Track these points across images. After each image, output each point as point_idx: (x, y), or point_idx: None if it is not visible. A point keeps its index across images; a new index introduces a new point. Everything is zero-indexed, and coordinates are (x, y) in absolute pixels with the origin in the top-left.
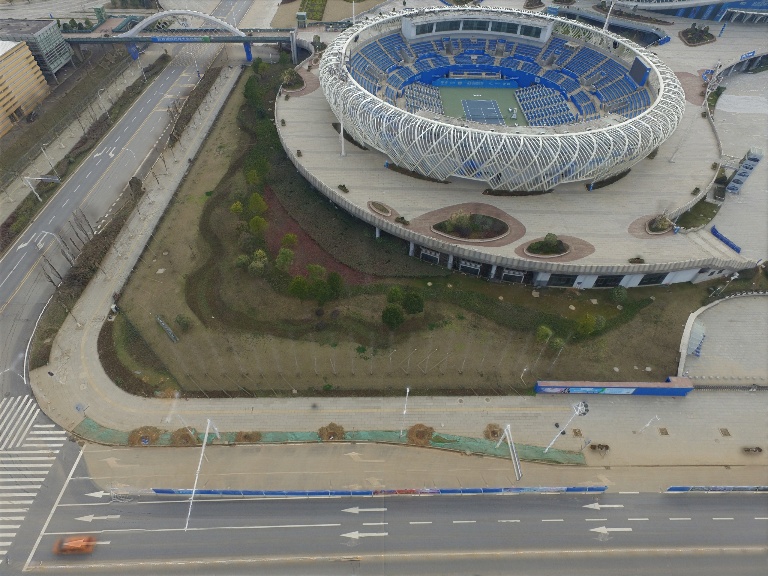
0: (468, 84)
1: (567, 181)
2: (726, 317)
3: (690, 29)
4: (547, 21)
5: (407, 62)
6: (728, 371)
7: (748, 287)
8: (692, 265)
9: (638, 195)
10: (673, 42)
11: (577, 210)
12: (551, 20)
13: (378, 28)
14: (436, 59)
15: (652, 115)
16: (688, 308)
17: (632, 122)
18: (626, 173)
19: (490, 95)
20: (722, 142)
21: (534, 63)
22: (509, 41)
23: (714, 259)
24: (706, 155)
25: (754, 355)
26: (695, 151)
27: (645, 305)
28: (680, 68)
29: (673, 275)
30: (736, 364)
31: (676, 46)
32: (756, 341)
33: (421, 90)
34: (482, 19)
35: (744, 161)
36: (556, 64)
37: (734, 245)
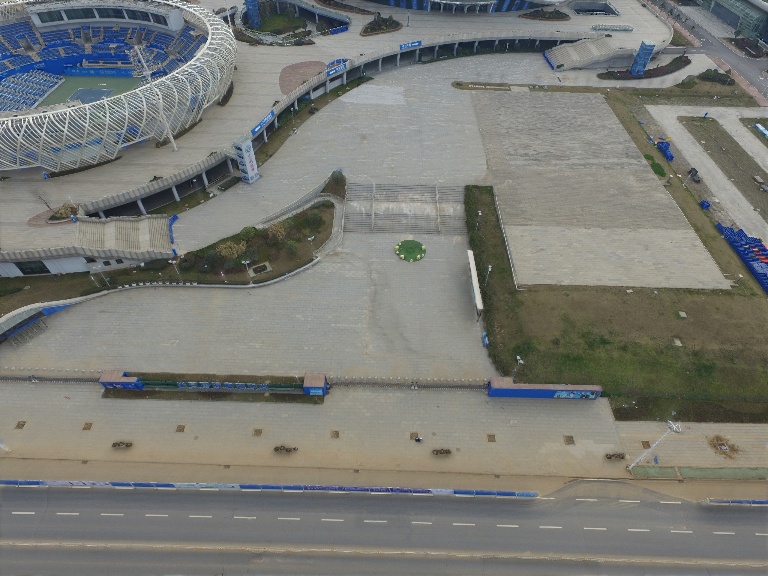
0: (101, 73)
1: (4, 169)
2: (100, 308)
3: (377, 18)
4: (172, 9)
5: (34, 50)
6: (34, 362)
7: (156, 278)
8: (51, 254)
9: (91, 184)
10: (350, 32)
11: (5, 198)
12: (177, 8)
13: (11, 16)
14: (69, 47)
15: (111, 102)
16: (48, 298)
17: (77, 109)
18: (109, 162)
19: (116, 84)
20: (300, 132)
21: (164, 52)
22: (150, 29)
23: (76, 248)
24: (221, 144)
25: (82, 346)
26: (215, 140)
27: (2, 294)
28: (320, 57)
29: (53, 264)
30: (51, 355)
31: (347, 35)
32: (102, 332)
33: (37, 79)
34: (113, 7)
35: (235, 150)
36: (178, 53)
37: (170, 235)
